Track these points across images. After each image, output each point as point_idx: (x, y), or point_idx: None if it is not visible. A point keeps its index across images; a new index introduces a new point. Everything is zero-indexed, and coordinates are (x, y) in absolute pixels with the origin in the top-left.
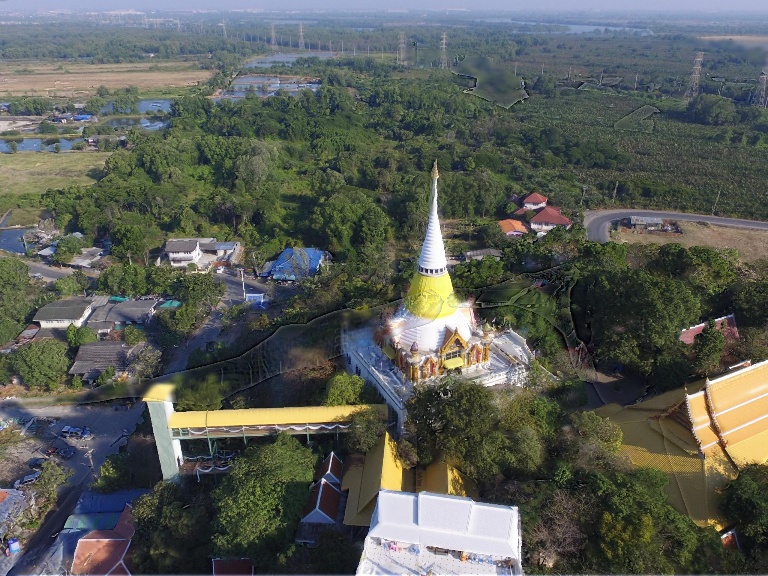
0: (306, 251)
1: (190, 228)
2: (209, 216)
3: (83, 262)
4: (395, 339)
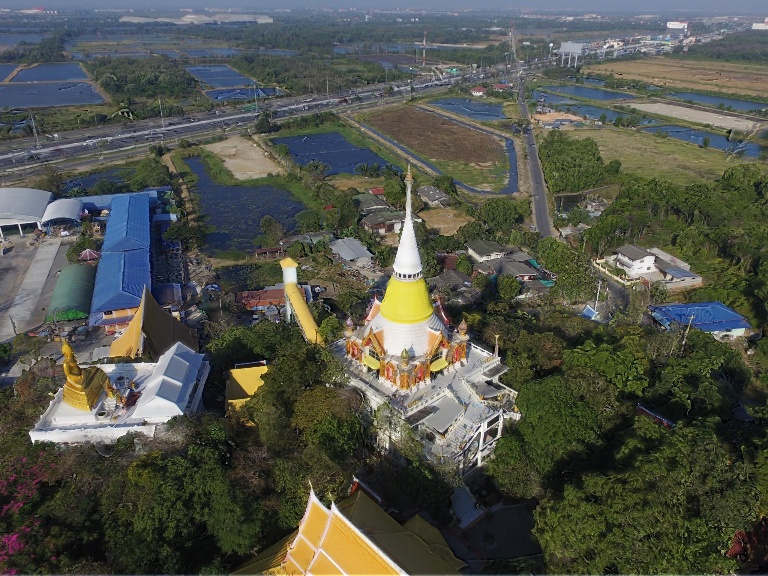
0: (725, 313)
1: (689, 248)
2: (719, 246)
3: (567, 232)
4: (368, 316)
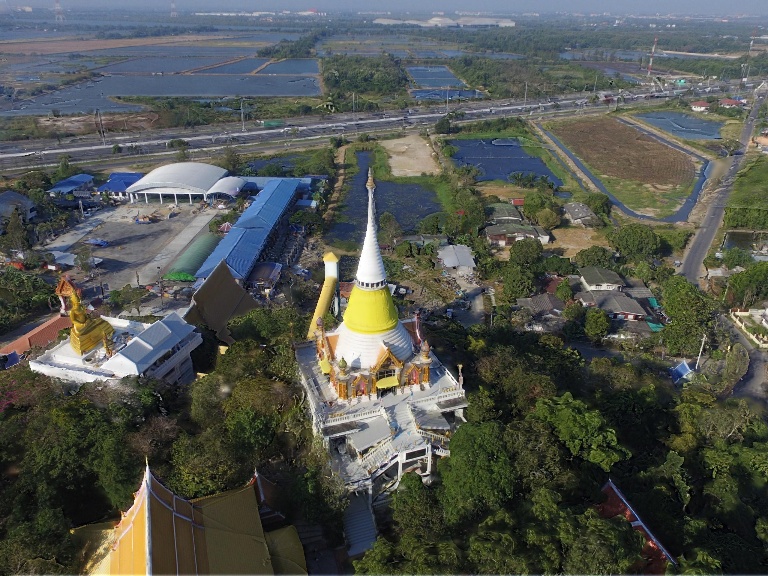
0: None
1: None
2: None
3: (715, 273)
4: None
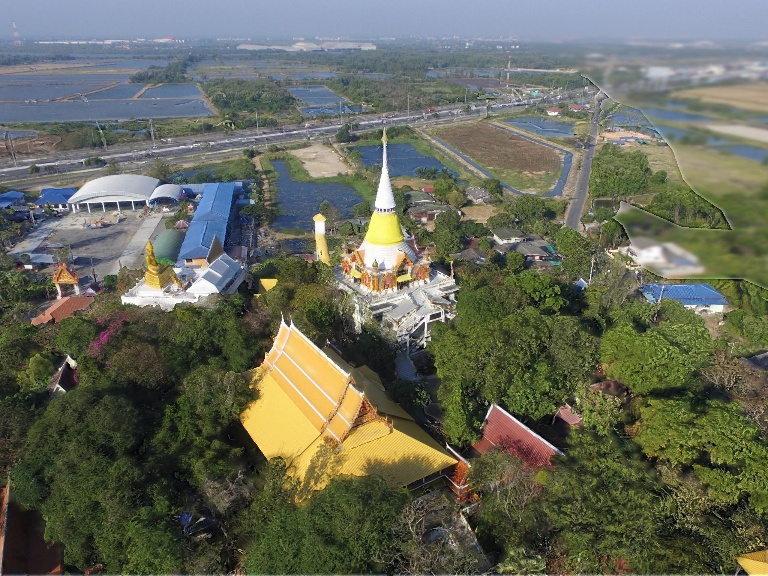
0: (707, 291)
1: None
2: None
3: None
4: None
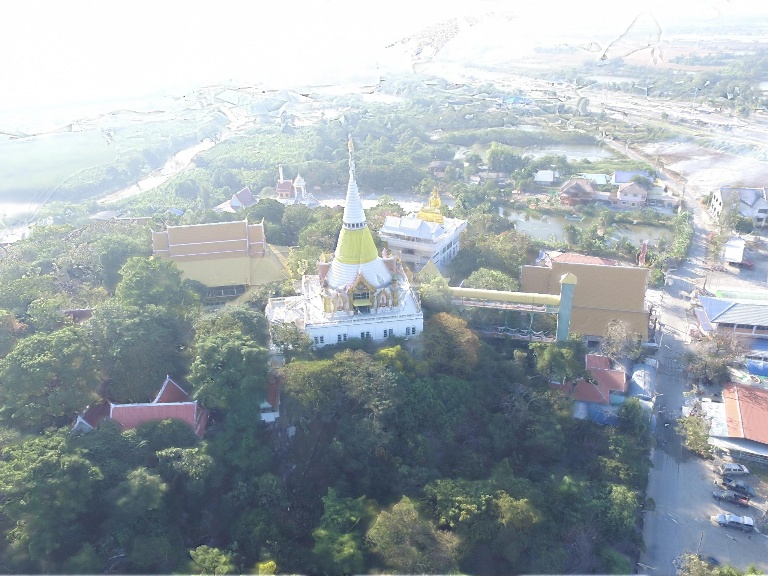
0: None
1: None
2: None
3: None
4: None
